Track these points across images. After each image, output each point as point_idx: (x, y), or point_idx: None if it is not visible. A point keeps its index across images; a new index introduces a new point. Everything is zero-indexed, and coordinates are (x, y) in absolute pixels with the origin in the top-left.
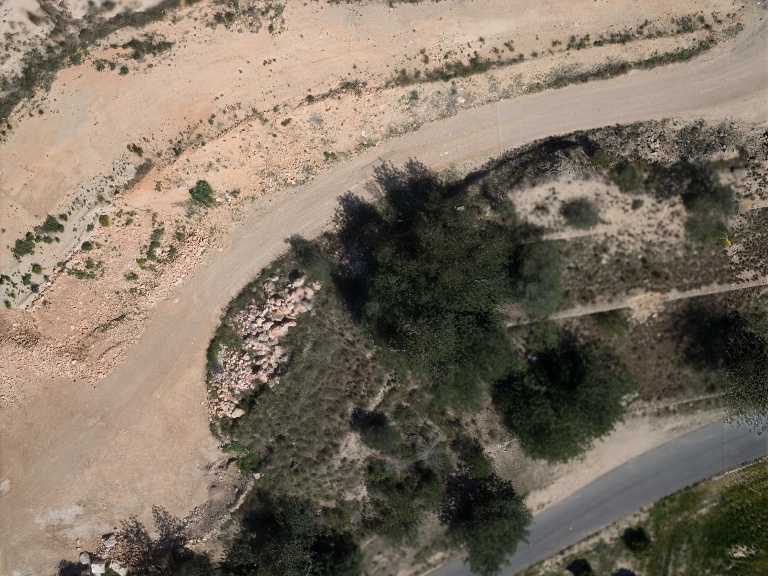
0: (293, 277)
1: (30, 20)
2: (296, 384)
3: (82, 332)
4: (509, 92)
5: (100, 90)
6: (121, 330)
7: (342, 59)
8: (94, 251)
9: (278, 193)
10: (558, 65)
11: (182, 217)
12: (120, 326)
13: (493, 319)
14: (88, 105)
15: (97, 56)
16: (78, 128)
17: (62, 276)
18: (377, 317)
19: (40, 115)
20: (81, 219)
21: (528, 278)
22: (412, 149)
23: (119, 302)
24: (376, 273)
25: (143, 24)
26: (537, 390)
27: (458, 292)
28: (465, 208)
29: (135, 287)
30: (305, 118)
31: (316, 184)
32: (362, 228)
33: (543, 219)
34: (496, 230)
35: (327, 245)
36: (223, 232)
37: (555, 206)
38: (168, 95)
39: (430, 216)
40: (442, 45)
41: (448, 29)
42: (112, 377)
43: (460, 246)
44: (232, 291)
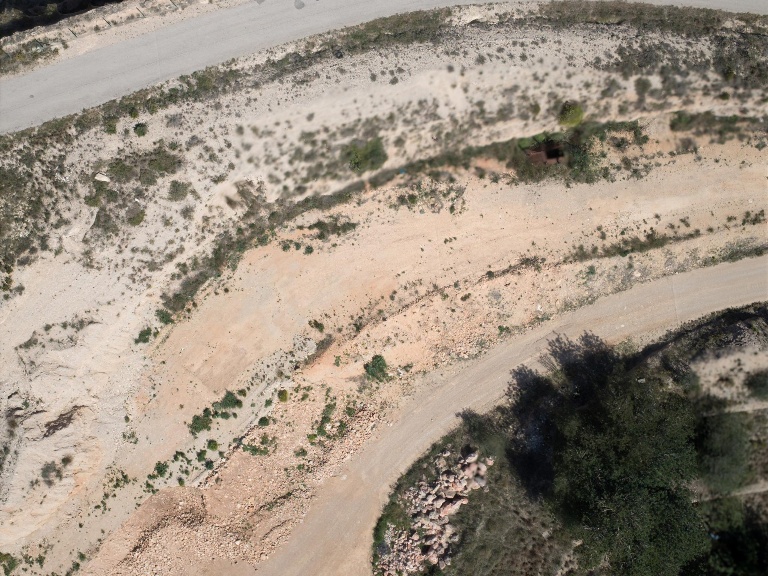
0: (466, 452)
1: (228, 204)
2: (469, 565)
3: (247, 510)
4: (684, 266)
5: (284, 269)
6: (287, 508)
7: (521, 236)
8: (270, 426)
9: (450, 367)
10: (733, 239)
11: (353, 392)
12: (286, 504)
13: (681, 495)
14: (272, 283)
15: (283, 237)
16: (261, 305)
17: (237, 452)
18: (565, 493)
19: (225, 293)
20: (260, 394)
21: (712, 452)
22: (587, 322)
23: (286, 479)
24: (564, 447)
25: (329, 207)
26: (723, 572)
27: (649, 466)
28: (646, 380)
29: (303, 463)
30: (484, 293)
31: (489, 358)
32: (537, 402)
33: (726, 391)
34: (678, 402)
35: (500, 419)
36: (393, 407)
37: (739, 377)
38: (351, 273)
39: (618, 388)
40: (618, 222)
41: (624, 207)
42: (274, 558)
43: (648, 419)
44: (401, 467)
